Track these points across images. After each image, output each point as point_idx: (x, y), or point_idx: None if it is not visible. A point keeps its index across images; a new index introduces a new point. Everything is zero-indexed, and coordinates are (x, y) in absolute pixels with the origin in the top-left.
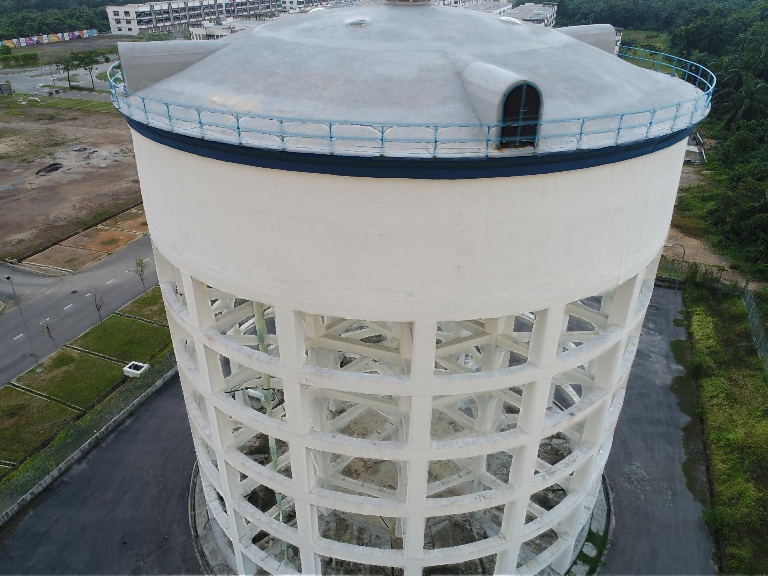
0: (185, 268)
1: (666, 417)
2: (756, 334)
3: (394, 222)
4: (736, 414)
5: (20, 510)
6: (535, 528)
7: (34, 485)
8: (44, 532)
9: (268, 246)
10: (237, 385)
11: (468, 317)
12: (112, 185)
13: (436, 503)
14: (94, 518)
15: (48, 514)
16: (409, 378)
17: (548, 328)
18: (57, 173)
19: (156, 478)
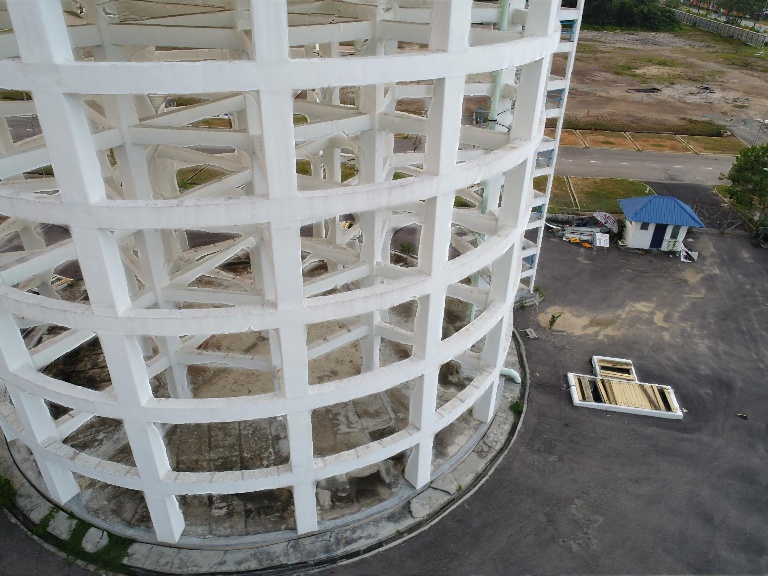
0: None
1: None
2: None
3: None
4: None
5: None
6: None
7: None
8: None
9: None
10: None
11: None
12: (658, 114)
13: None
14: None
15: None
16: None
17: None
18: (641, 94)
19: None
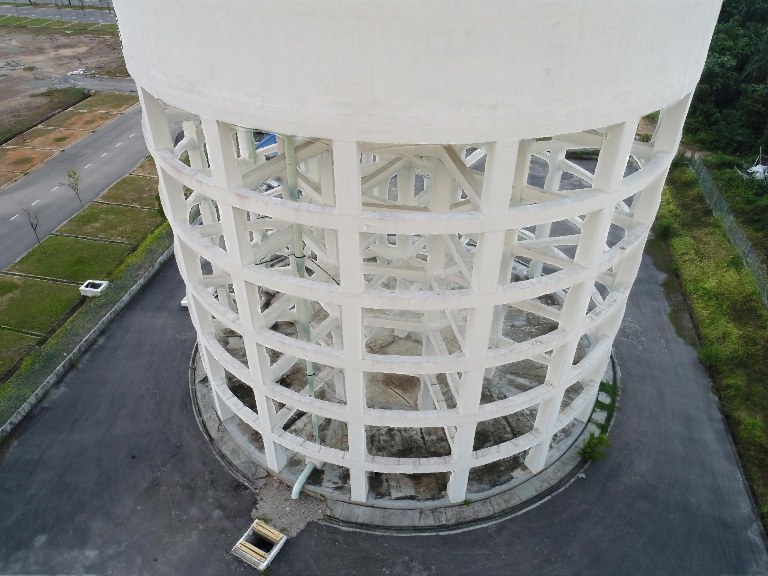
0: (208, 111)
1: (645, 276)
2: (709, 196)
3: (484, 14)
4: (706, 267)
5: (2, 442)
6: (578, 372)
7: (12, 414)
8: (37, 459)
9: (328, 61)
10: (264, 257)
11: (551, 132)
12: (7, 101)
13: (495, 353)
14: (91, 438)
15: (36, 441)
16: (481, 213)
17: (622, 145)
18: None
19: (150, 391)
